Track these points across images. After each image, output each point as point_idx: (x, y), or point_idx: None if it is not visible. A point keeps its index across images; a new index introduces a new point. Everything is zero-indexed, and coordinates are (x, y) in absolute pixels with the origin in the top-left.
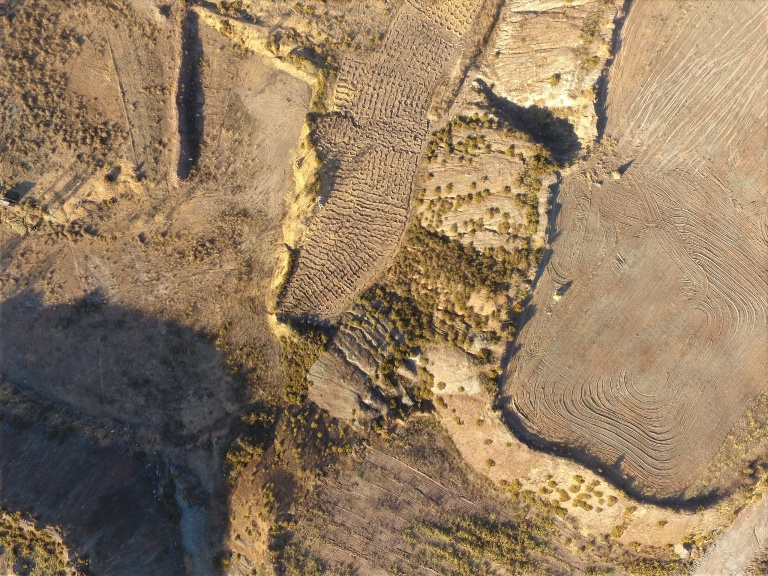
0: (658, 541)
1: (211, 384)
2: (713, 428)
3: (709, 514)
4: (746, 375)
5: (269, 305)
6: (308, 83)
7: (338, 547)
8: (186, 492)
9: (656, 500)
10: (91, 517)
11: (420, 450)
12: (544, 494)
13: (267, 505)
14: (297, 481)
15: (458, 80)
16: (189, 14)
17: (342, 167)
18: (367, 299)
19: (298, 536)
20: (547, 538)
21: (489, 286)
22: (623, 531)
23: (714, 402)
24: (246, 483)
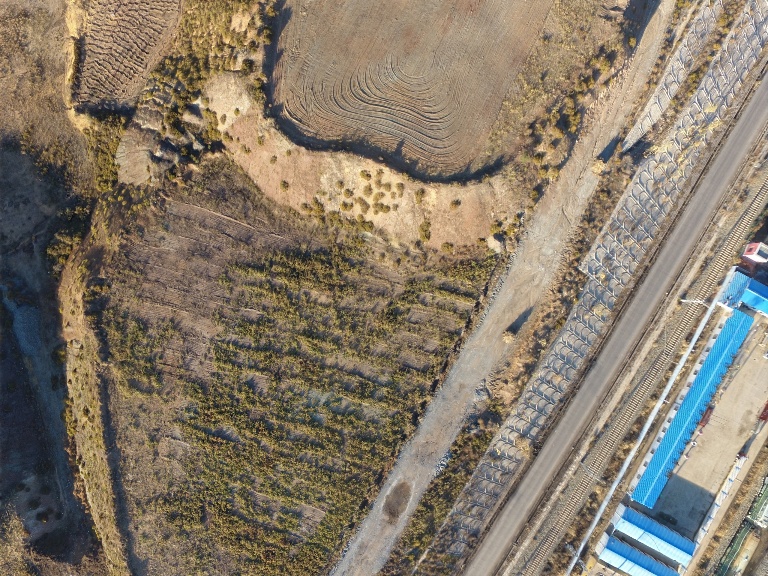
0: (467, 236)
1: (24, 190)
2: (487, 98)
3: (497, 183)
4: (512, 39)
5: (67, 101)
6: None
7: (156, 304)
8: (10, 292)
9: (442, 178)
10: None
11: (220, 193)
12: (348, 212)
13: (80, 277)
14: (106, 248)
15: None
16: None
17: None
18: (157, 71)
19: (114, 300)
20: (361, 258)
21: (244, 1)
22: (430, 231)
23: (484, 72)
24: (68, 272)
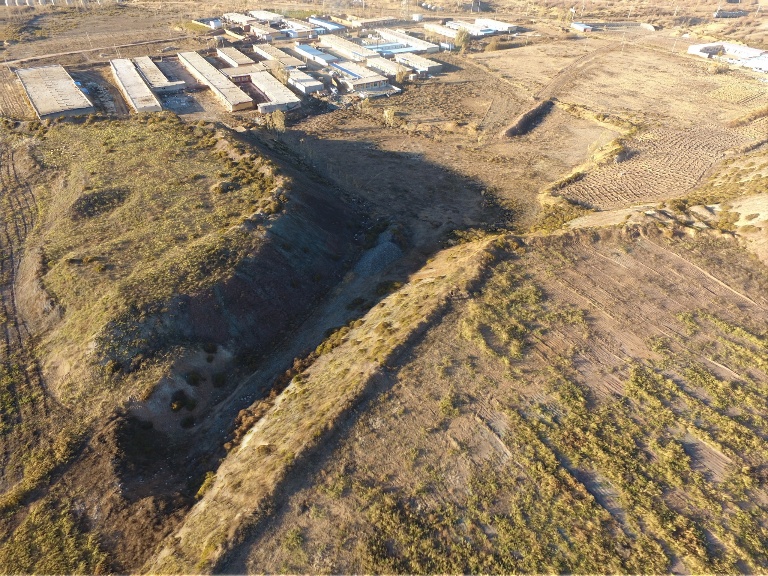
0: None
1: (461, 207)
2: None
3: None
4: None
5: None
6: (620, 133)
7: (573, 289)
8: (398, 229)
9: None
10: (310, 195)
11: (714, 259)
12: None
13: None
14: None
15: (756, 142)
16: (549, 102)
17: (640, 154)
18: None
19: (523, 262)
20: None
21: None
22: None
23: None
24: None
